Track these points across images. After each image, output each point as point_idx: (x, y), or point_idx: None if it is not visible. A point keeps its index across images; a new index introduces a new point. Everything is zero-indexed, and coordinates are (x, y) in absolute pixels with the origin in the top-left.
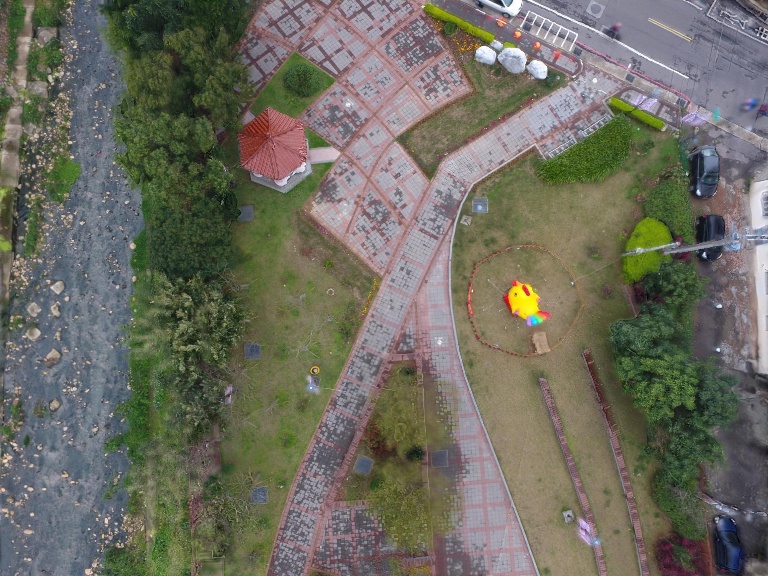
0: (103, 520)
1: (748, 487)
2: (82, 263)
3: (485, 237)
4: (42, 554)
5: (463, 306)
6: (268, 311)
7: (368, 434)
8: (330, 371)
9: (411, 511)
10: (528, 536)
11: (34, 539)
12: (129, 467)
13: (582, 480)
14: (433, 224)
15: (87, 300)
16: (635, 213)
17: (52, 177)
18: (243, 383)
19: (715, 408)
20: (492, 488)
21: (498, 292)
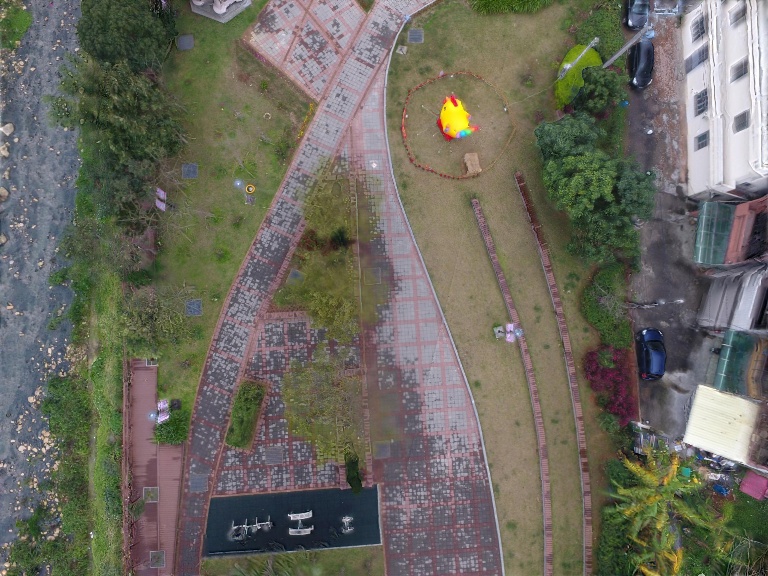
0: (47, 350)
1: (677, 304)
2: (32, 107)
3: (420, 66)
4: None
5: (397, 131)
6: (206, 133)
7: (300, 247)
8: (265, 191)
9: (343, 326)
10: (459, 350)
11: None
12: (73, 299)
13: (513, 297)
14: (369, 54)
15: (36, 141)
16: (568, 43)
17: (4, 25)
18: (180, 200)
19: (631, 194)
20: (424, 305)
21: (432, 118)
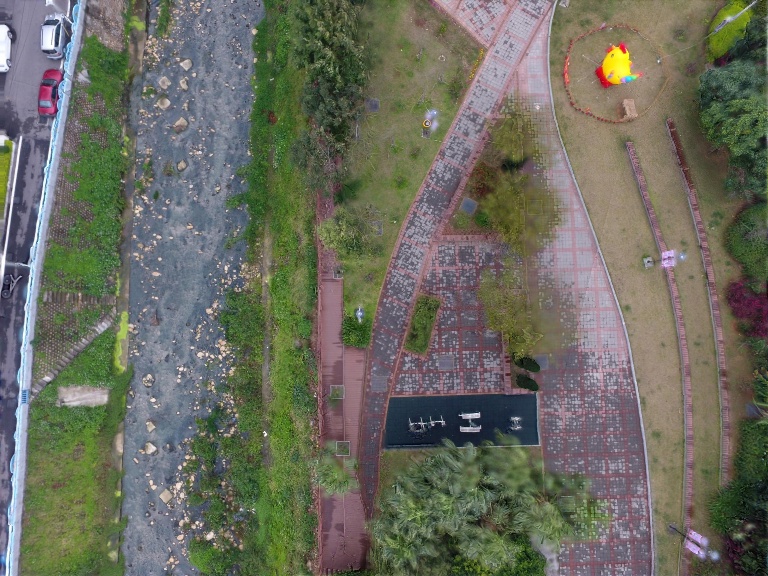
0: (223, 267)
1: None
2: (208, 45)
3: (581, 18)
4: (168, 294)
5: (560, 77)
6: (386, 71)
7: (474, 177)
8: (440, 126)
9: (508, 250)
10: (612, 277)
11: (161, 281)
12: (248, 222)
13: (662, 231)
14: (535, 5)
15: (212, 77)
16: (717, 3)
17: None
18: (363, 131)
19: None
20: (581, 235)
21: (591, 66)
